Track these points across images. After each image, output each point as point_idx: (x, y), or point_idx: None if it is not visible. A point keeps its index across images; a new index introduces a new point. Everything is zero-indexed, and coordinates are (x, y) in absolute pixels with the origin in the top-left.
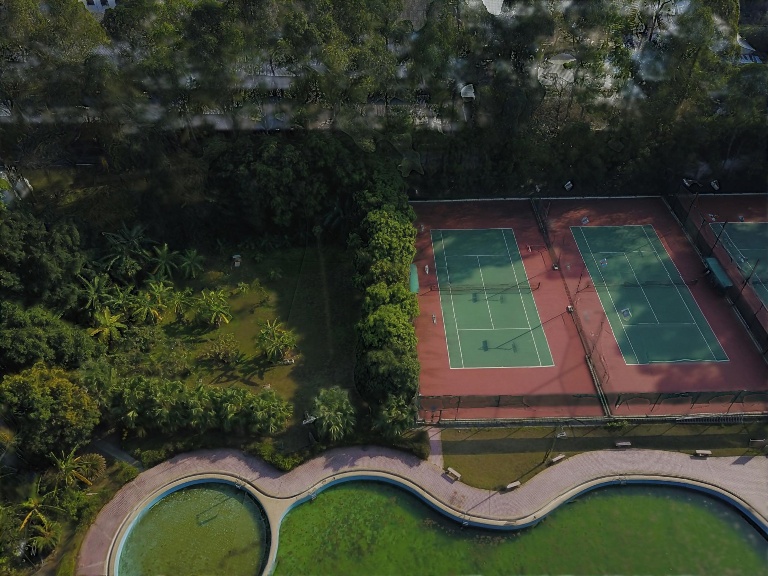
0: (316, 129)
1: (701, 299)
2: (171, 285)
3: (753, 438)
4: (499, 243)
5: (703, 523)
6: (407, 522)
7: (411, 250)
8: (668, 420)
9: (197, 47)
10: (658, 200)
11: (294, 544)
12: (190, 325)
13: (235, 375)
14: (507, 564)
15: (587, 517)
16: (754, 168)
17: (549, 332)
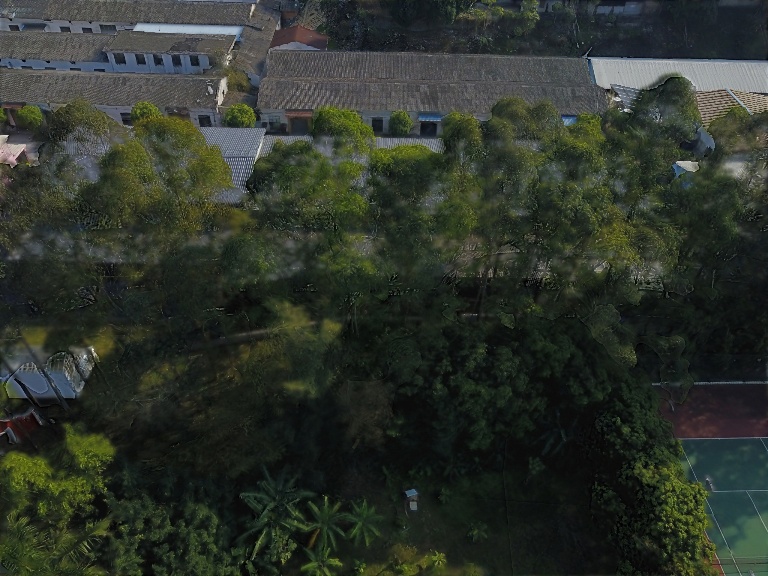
0: (531, 315)
1: None
2: (339, 568)
3: None
4: (767, 466)
5: None
6: None
7: None
8: None
9: (406, 232)
10: None
11: None
12: None
13: None
14: None
15: None
16: None
17: None
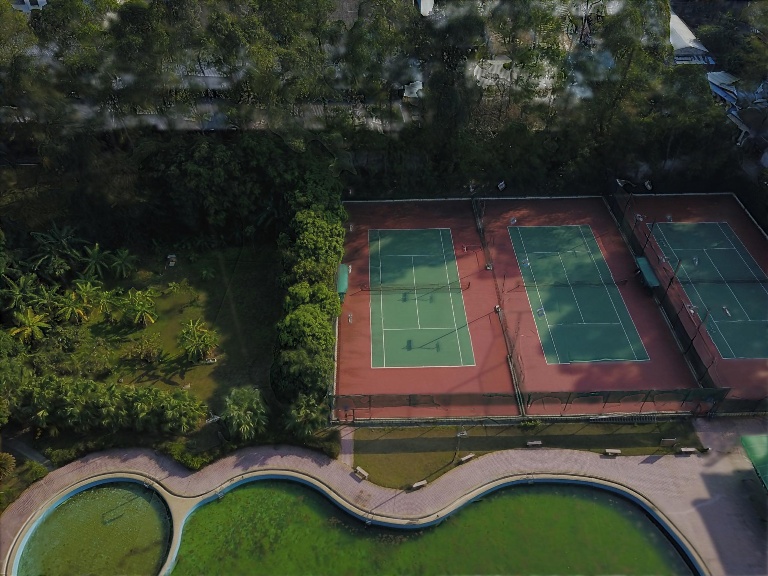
0: (250, 129)
1: (629, 299)
2: (100, 285)
3: (665, 437)
4: (435, 243)
5: (606, 522)
6: (312, 521)
7: (338, 250)
8: (582, 419)
9: (121, 47)
10: (599, 200)
11: (196, 543)
12: (118, 325)
13: (156, 374)
14: (407, 563)
15: (491, 516)
16: (693, 168)
17: (474, 332)
